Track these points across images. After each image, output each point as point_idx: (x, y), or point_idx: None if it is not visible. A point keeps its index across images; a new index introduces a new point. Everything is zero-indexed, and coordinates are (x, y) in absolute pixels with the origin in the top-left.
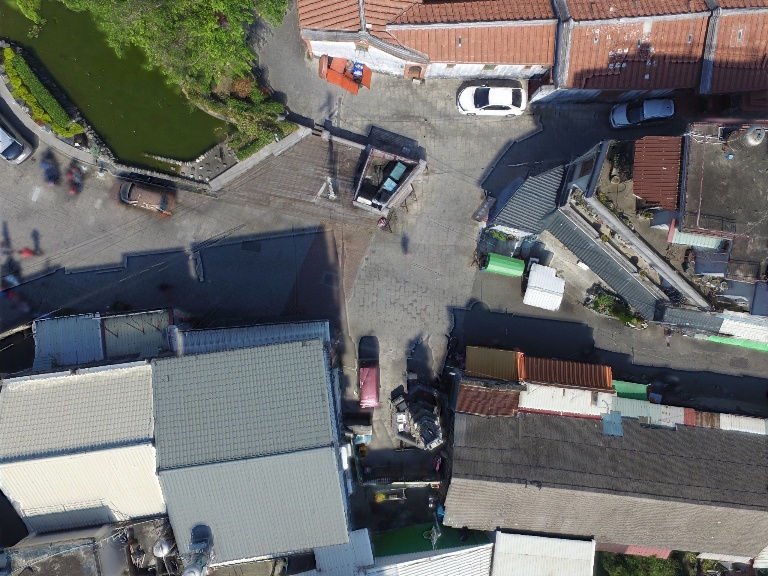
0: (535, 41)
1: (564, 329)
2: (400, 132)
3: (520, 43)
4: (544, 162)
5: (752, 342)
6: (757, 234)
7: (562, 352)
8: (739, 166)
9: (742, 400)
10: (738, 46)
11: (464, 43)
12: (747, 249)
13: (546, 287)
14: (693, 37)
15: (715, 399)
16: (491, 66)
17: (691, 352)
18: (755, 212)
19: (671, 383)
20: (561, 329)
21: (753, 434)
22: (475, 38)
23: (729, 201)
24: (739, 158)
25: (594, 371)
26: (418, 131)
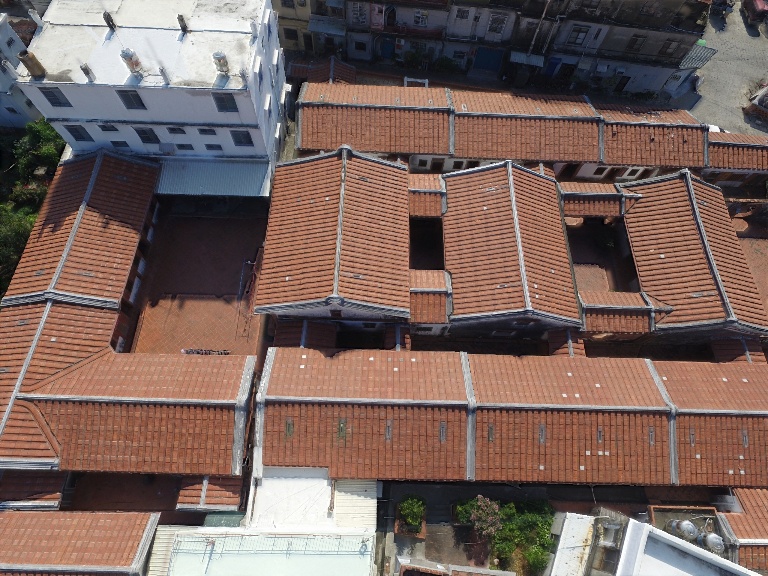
0: None
1: None
2: (765, 134)
3: None
4: (659, 105)
5: None
6: None
7: None
8: None
9: None
10: None
11: (764, 141)
12: None
13: None
14: (607, 117)
15: None
16: None
17: None
18: None
19: None
20: None
21: None
22: None
23: None
24: None
25: None
26: (752, 133)
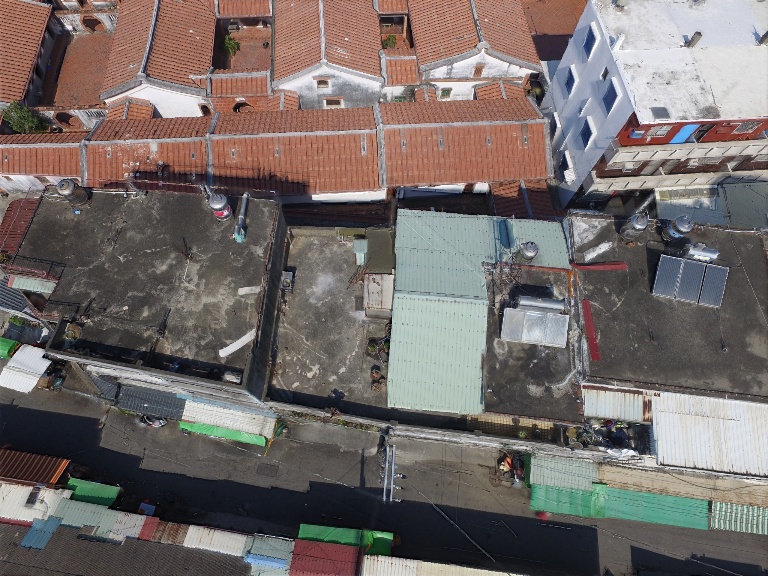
0: (72, 159)
1: (71, 424)
2: None
3: (59, 160)
4: None
5: (221, 429)
6: (84, 277)
7: (61, 451)
8: (84, 220)
9: (268, 520)
10: (233, 161)
11: (9, 159)
12: (70, 291)
13: (26, 367)
14: (196, 155)
15: (234, 517)
16: (45, 179)
17: (213, 455)
18: (88, 258)
19: (170, 491)
20: (68, 424)
21: (224, 555)
22: (20, 156)
23: (64, 248)
24: (86, 213)
25: (47, 464)
26: None
